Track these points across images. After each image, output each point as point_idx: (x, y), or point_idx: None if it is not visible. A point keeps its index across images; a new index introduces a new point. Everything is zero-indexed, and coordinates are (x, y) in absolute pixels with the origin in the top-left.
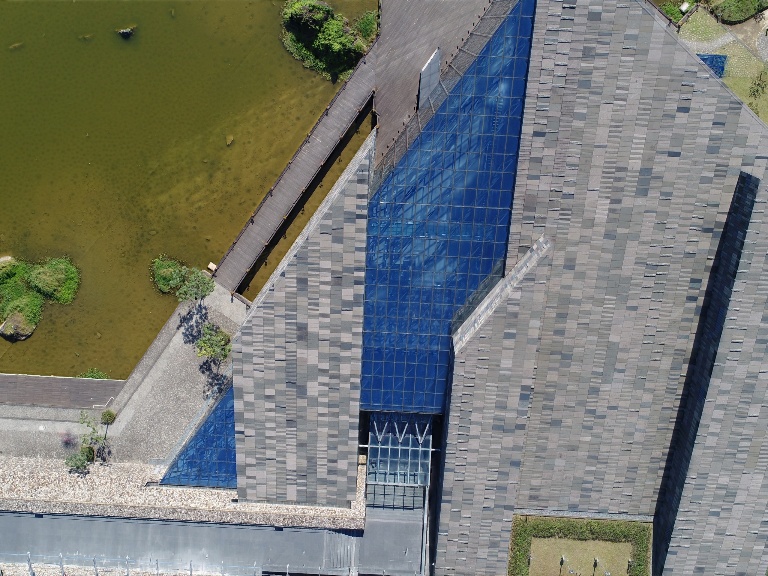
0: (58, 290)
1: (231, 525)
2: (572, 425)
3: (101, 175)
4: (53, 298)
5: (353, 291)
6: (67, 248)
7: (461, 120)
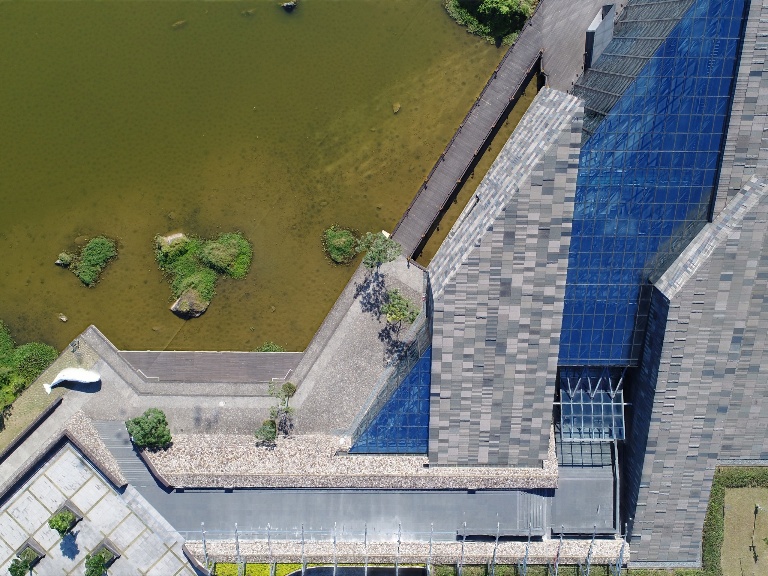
0: (231, 265)
1: (423, 491)
2: None
3: (269, 148)
4: (226, 273)
5: (560, 243)
6: (238, 223)
7: (676, 64)
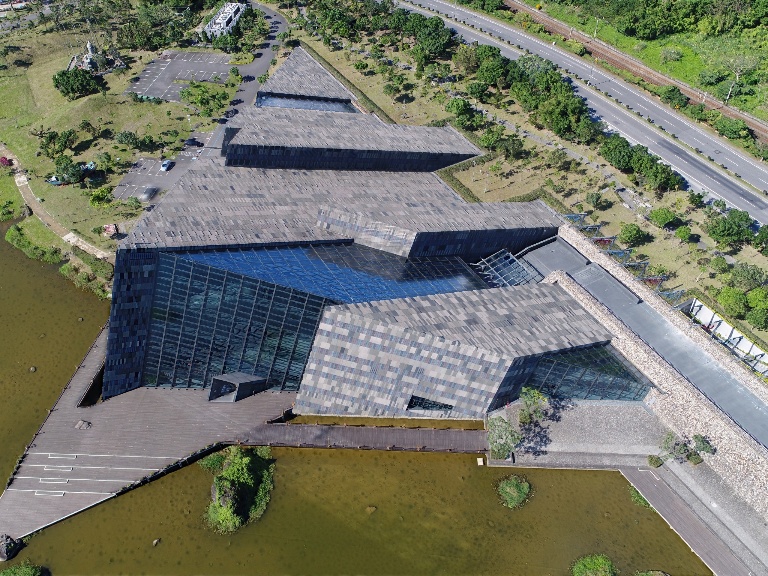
0: (604, 570)
1: None
2: None
3: None
4: (614, 572)
5: (422, 302)
6: None
7: None
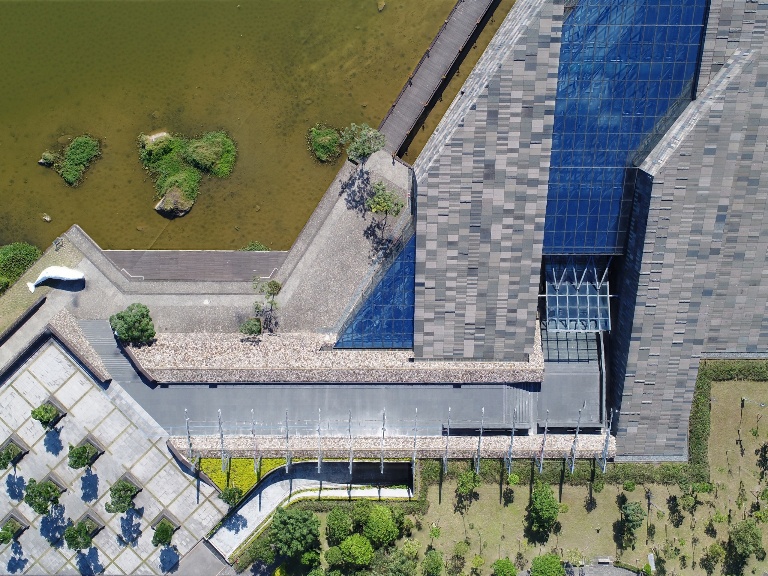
0: (216, 163)
1: (408, 385)
2: (755, 257)
3: (253, 47)
4: (210, 172)
5: (543, 122)
6: (222, 121)
7: None
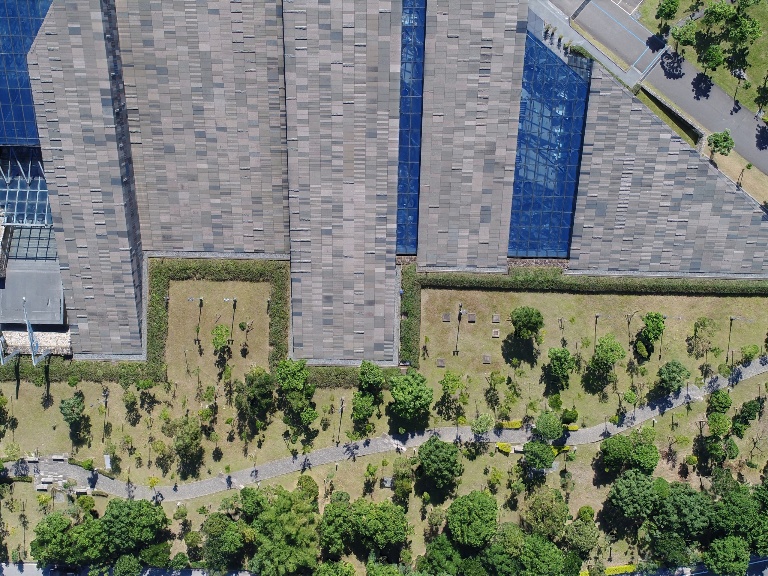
0: None
1: None
2: (186, 151)
3: None
4: None
5: None
6: None
7: None
